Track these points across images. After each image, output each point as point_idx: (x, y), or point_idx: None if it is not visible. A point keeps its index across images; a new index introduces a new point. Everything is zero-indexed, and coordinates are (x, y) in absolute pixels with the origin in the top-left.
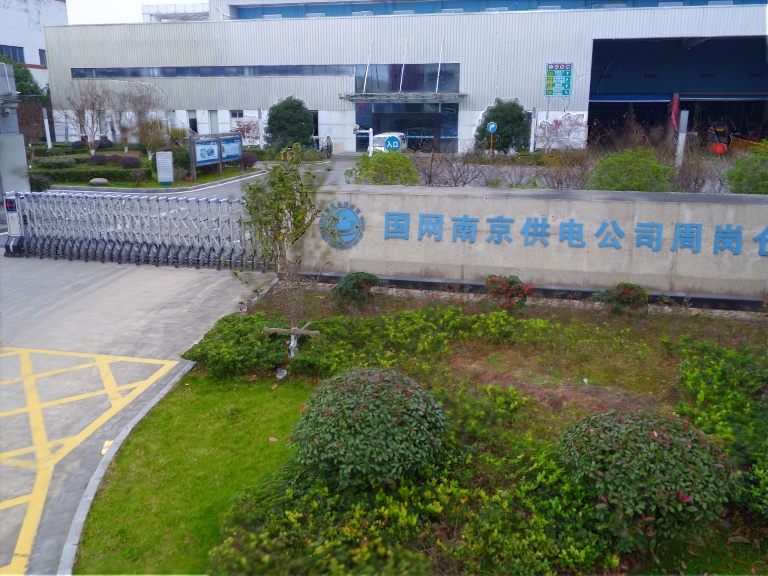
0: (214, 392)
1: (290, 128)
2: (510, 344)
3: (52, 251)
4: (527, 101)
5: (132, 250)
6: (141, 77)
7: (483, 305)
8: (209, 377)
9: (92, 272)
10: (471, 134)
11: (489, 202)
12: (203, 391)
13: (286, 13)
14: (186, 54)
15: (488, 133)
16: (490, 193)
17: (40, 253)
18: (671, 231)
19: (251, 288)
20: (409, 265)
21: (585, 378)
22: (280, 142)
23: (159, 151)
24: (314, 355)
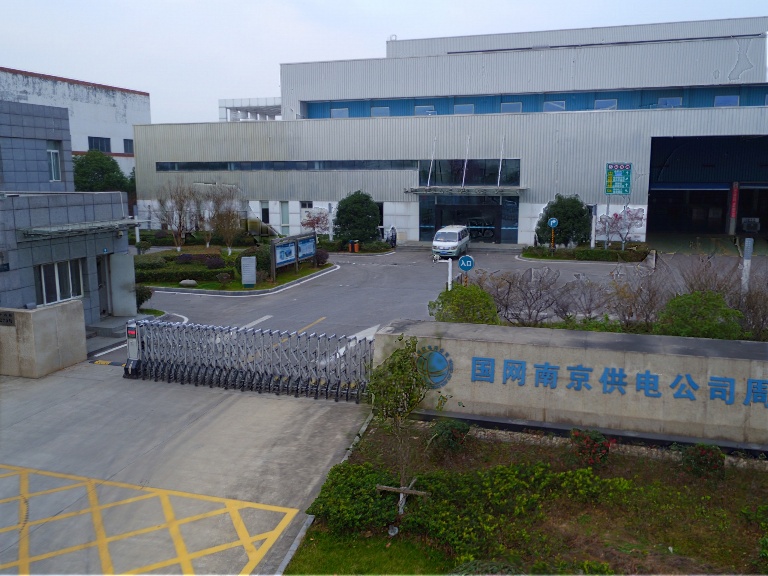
0: (337, 549)
1: (358, 221)
2: (597, 504)
3: (165, 374)
4: (586, 195)
5: (237, 377)
6: (219, 170)
7: (568, 459)
8: (331, 533)
9: (203, 399)
10: (531, 225)
11: (569, 352)
12: (327, 548)
13: (353, 107)
14: (261, 150)
15: (549, 228)
16: (569, 340)
17: (154, 375)
18: (743, 386)
19: (349, 423)
20: (494, 406)
21: (670, 546)
22: (348, 234)
23: (243, 255)
24: (423, 516)
